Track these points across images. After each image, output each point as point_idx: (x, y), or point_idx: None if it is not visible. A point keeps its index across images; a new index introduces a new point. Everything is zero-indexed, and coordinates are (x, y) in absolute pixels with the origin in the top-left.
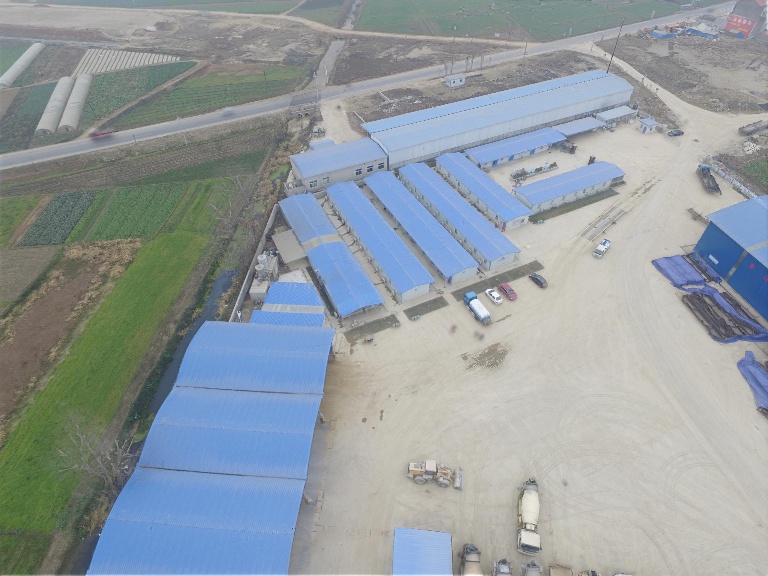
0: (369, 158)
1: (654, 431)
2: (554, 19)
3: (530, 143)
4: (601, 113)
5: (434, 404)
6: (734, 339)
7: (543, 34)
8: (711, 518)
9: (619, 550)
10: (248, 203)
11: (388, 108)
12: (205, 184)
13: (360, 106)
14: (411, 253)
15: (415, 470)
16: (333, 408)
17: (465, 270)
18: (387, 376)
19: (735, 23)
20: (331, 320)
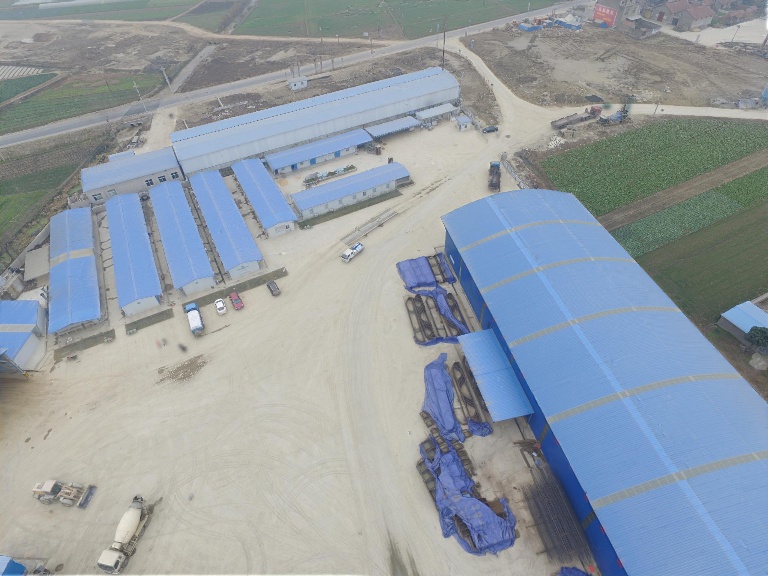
0: (159, 168)
1: (307, 440)
2: (434, 15)
3: (333, 146)
4: (421, 112)
5: (105, 421)
6: (435, 341)
7: (415, 31)
8: (316, 528)
9: (208, 564)
10: (34, 219)
11: (218, 114)
12: (2, 200)
13: (193, 113)
14: (153, 265)
15: (36, 491)
16: (3, 429)
17: (197, 281)
18: (74, 393)
19: (600, 13)
20: (49, 337)
